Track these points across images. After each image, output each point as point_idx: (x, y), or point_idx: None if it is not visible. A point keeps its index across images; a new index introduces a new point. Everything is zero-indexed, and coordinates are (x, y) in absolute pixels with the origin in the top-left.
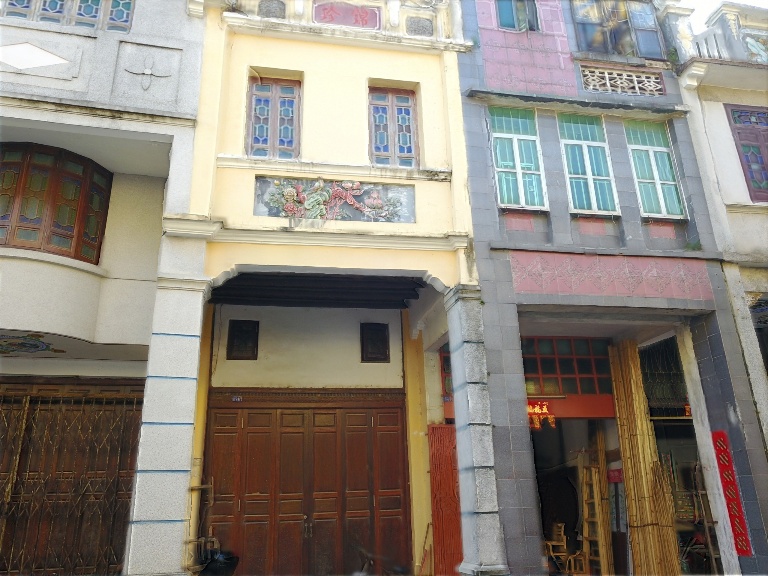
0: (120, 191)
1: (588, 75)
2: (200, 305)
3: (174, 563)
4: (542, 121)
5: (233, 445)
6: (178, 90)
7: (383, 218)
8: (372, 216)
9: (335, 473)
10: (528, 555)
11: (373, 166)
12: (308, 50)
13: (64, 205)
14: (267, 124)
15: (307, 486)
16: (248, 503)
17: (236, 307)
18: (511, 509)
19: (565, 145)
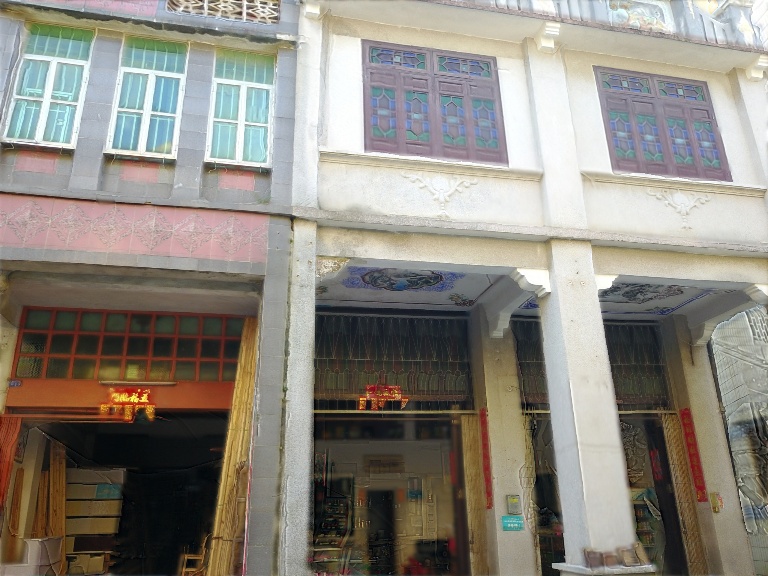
0: None
1: None
2: None
3: None
4: (101, 44)
5: None
6: None
7: None
8: None
9: None
10: None
11: None
12: None
13: None
14: None
15: None
16: None
17: None
18: None
19: (125, 73)
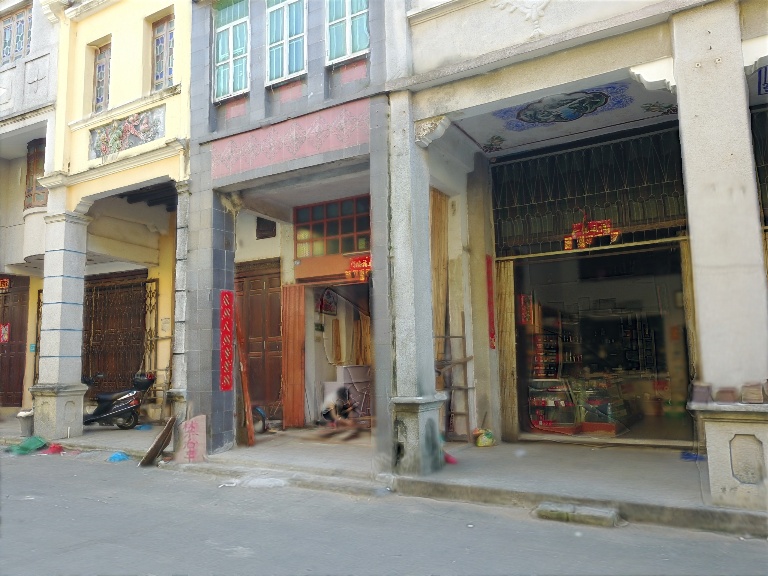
0: None
1: None
2: (64, 230)
3: (54, 379)
4: None
5: None
6: (48, 85)
7: (150, 138)
8: (144, 139)
9: (242, 325)
10: (200, 384)
11: (153, 94)
12: (109, 15)
13: None
14: (103, 85)
15: None
16: None
17: None
18: (193, 351)
19: (270, 13)
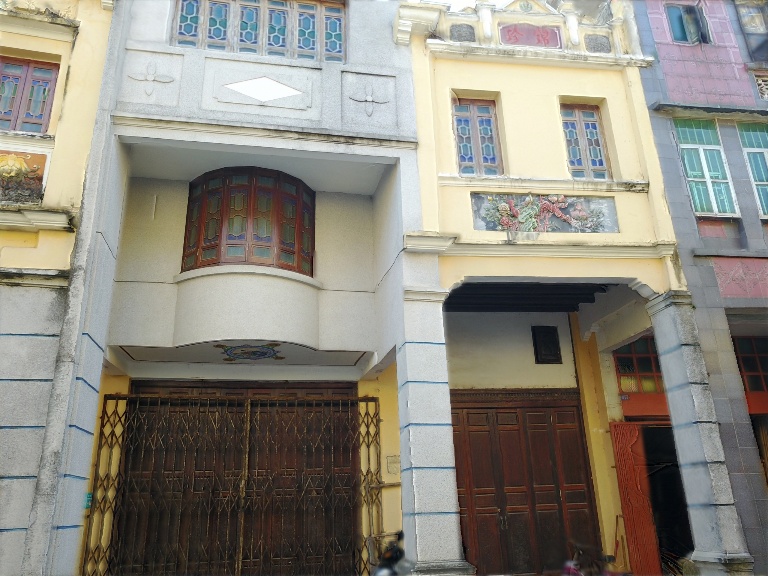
0: (323, 208)
1: (762, 84)
2: None
3: (455, 551)
4: (724, 131)
5: None
6: (397, 115)
7: (589, 229)
8: (579, 227)
9: (522, 469)
10: (766, 544)
11: None
12: (503, 71)
13: (285, 223)
14: (470, 143)
15: (498, 481)
16: None
17: None
18: (745, 501)
19: (748, 153)
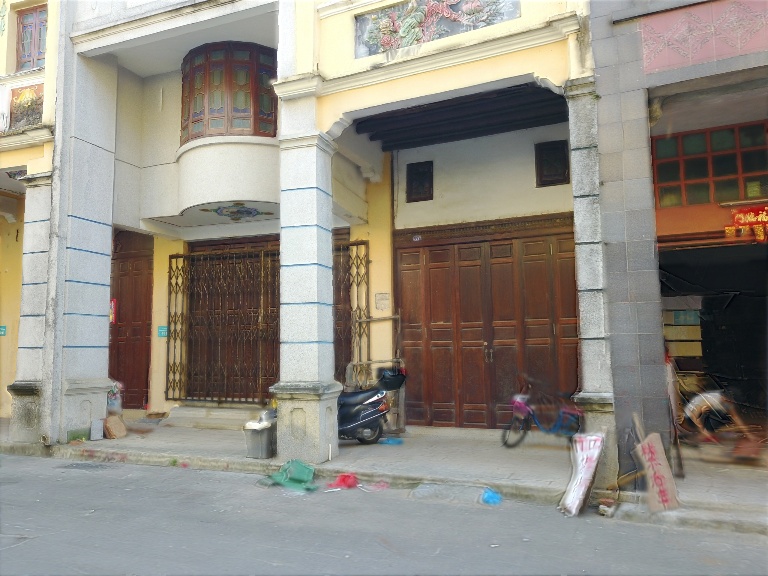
0: None
1: None
2: (315, 159)
3: (310, 374)
4: None
5: (418, 280)
6: None
7: (484, 22)
8: (472, 24)
9: (513, 303)
10: (641, 385)
11: None
12: None
13: (240, 91)
14: None
15: (486, 315)
16: (434, 331)
17: (408, 151)
18: (622, 335)
19: None
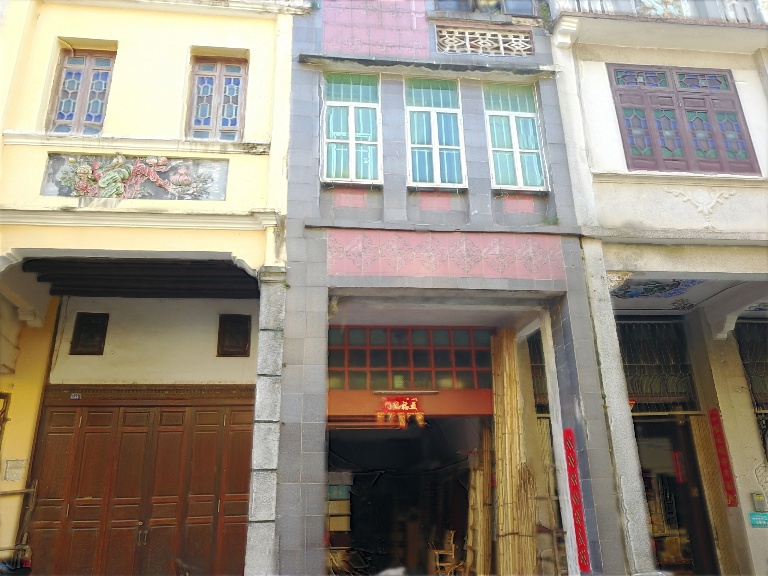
0: None
1: (445, 36)
2: None
3: None
4: (386, 87)
5: (68, 446)
6: None
7: (189, 196)
8: (177, 194)
9: (178, 476)
10: (306, 570)
11: (189, 140)
12: (123, 18)
13: None
14: (75, 98)
15: (146, 490)
16: (78, 508)
17: (82, 299)
18: (292, 517)
19: (410, 112)
